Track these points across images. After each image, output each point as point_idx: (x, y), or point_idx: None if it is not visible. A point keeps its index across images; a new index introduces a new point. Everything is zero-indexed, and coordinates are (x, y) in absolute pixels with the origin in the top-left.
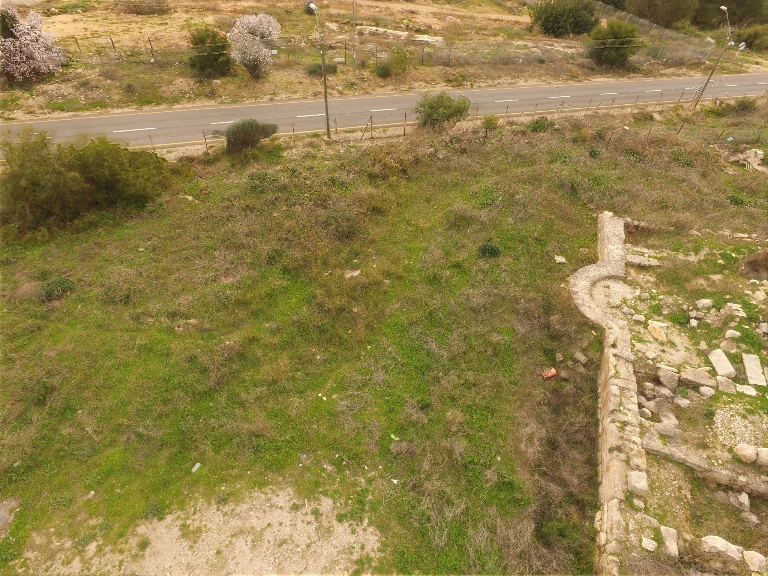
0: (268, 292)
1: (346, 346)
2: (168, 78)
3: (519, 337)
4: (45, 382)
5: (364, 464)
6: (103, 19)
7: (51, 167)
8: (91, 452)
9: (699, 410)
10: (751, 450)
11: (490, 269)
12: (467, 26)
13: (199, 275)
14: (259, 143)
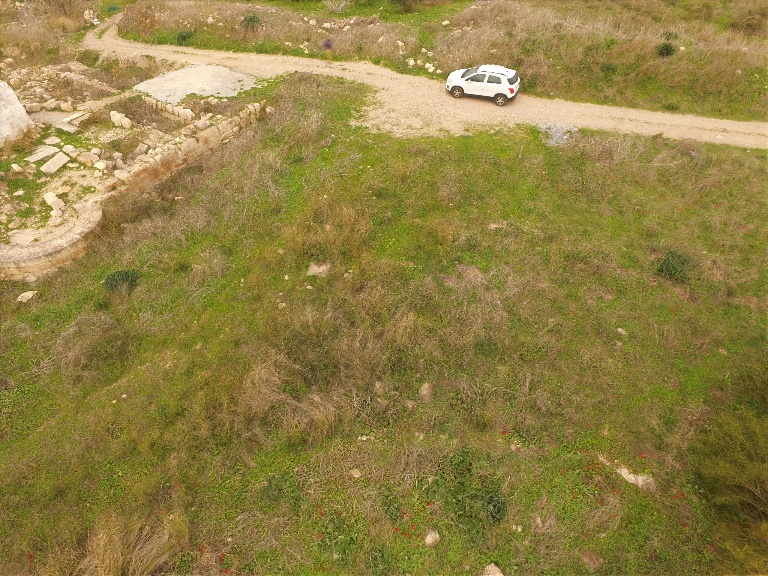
0: None
1: None
2: None
3: None
4: None
5: None
6: None
7: None
8: None
9: (117, 146)
10: (126, 118)
11: None
12: None
13: (511, 278)
14: None
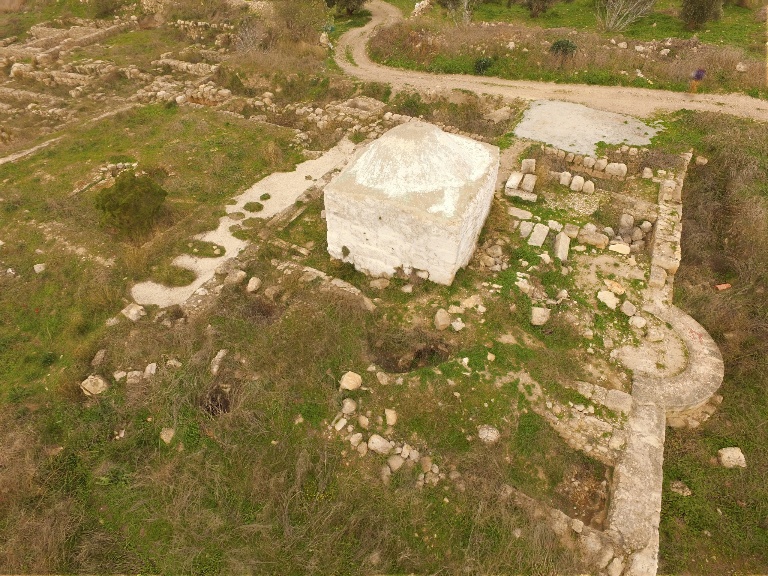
0: None
1: None
2: None
3: None
4: None
5: None
6: None
7: None
8: None
9: None
10: None
11: None
12: None
13: None
14: None
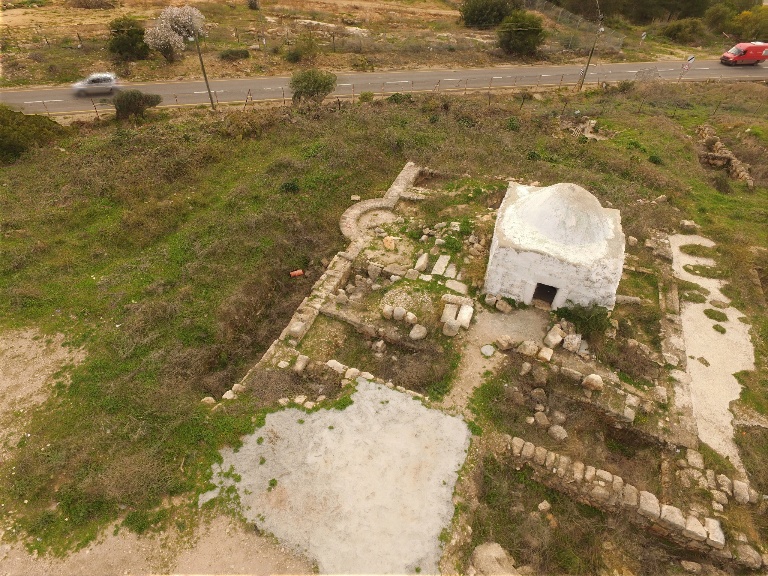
0: (88, 212)
1: (132, 248)
2: (90, 61)
3: (277, 246)
4: None
5: (101, 316)
6: (52, 12)
7: None
8: None
9: None
10: (388, 308)
11: (281, 200)
12: (384, 18)
13: None
14: (148, 112)
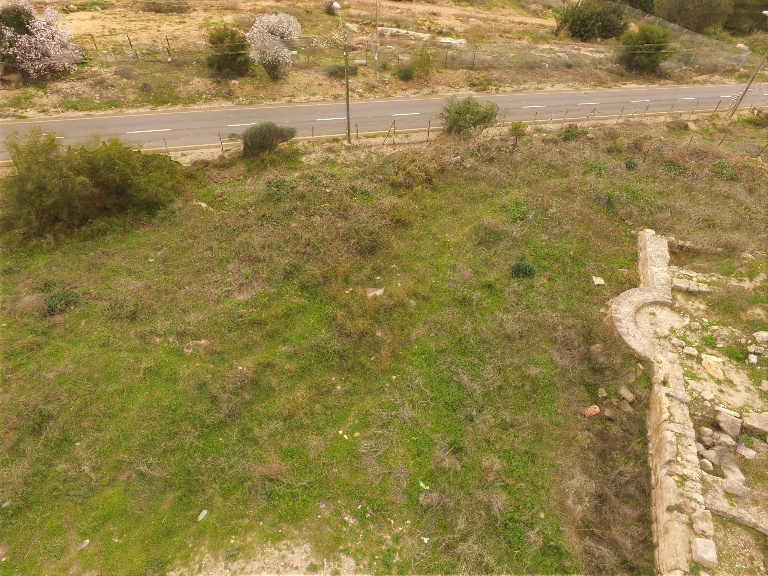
0: (285, 311)
1: (369, 375)
2: (185, 78)
3: (559, 370)
4: (41, 409)
5: (390, 517)
6: (121, 17)
7: (59, 171)
8: (87, 493)
9: (767, 463)
10: None
11: (524, 291)
12: (492, 29)
13: (211, 290)
14: (277, 147)
